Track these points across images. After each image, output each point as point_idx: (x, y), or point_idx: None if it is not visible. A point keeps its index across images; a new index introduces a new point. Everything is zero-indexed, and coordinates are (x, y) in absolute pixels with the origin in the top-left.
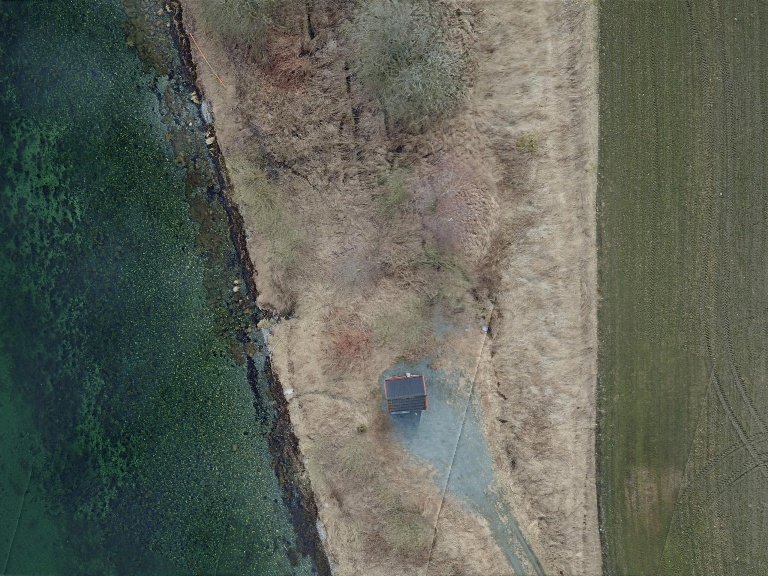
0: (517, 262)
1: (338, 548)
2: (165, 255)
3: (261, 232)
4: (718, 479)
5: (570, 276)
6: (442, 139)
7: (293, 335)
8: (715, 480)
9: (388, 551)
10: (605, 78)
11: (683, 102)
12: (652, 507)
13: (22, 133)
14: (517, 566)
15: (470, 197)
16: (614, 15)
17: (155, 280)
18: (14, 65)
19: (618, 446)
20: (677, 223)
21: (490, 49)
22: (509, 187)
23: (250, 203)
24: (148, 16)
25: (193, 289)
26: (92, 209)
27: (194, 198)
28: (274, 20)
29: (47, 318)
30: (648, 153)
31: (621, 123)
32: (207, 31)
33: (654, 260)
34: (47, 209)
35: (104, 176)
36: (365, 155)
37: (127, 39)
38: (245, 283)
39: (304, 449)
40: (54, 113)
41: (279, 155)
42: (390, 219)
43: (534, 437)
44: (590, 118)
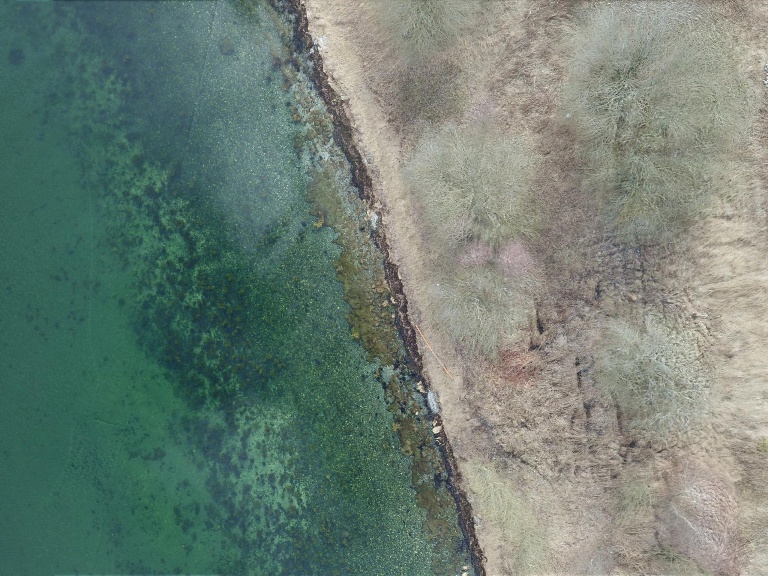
0: (756, 560)
1: None
2: (392, 541)
3: (490, 520)
4: None
5: None
6: (677, 436)
7: None
8: None
9: None
10: None
11: None
12: None
13: (246, 421)
14: None
15: (706, 494)
16: None
17: (382, 565)
18: (239, 356)
19: None
20: None
21: (729, 355)
22: (748, 488)
23: (479, 491)
24: (373, 307)
25: (421, 574)
26: (318, 495)
27: (421, 485)
28: None
29: None
30: None
31: None
32: (433, 323)
33: None
34: (272, 495)
35: (329, 463)
36: (597, 449)
37: (351, 329)
38: (474, 568)
39: None
40: (278, 401)
41: (508, 445)
42: (623, 511)
43: None
44: None
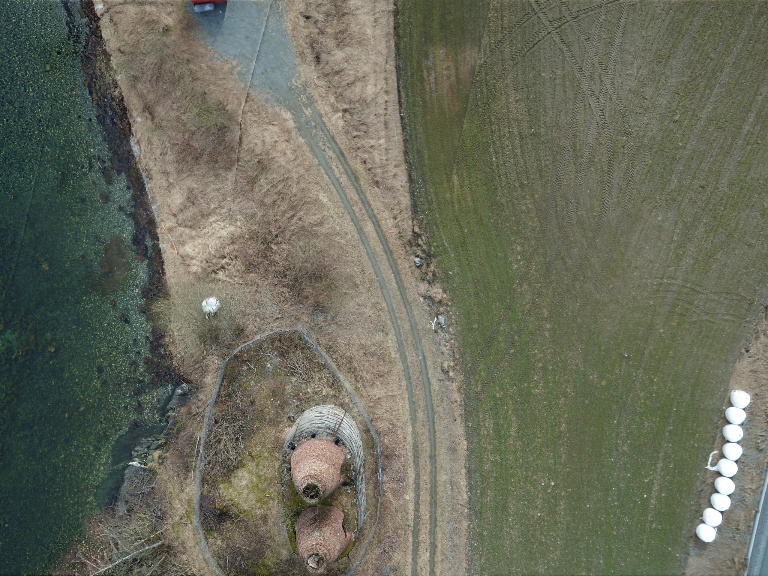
0: None
1: (151, 163)
2: None
3: None
4: (512, 51)
5: None
6: None
7: None
8: (510, 53)
9: (199, 159)
10: None
11: None
12: (450, 86)
13: None
14: (321, 157)
15: None
16: None
17: None
18: None
19: (416, 26)
20: None
21: None
22: None
23: None
24: None
25: None
26: None
27: None
28: None
29: None
30: None
31: None
32: None
33: None
34: None
35: None
36: None
37: None
38: None
39: (115, 63)
40: None
41: None
42: None
43: (335, 26)
44: None
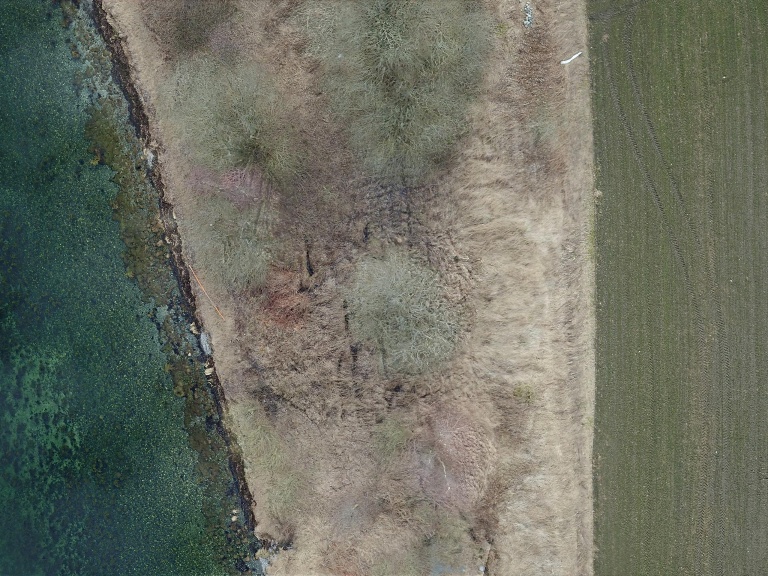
0: (514, 507)
1: None
2: (164, 483)
3: (259, 463)
4: None
5: (567, 527)
6: (440, 381)
7: (291, 566)
8: None
9: None
10: (602, 334)
11: (679, 361)
12: None
13: (22, 359)
14: None
15: (467, 439)
16: (611, 272)
17: (154, 507)
18: (14, 294)
19: None
20: (673, 479)
21: (488, 298)
22: (506, 433)
23: (249, 434)
24: (148, 247)
25: (192, 517)
26: (91, 436)
27: (193, 427)
28: (273, 255)
29: (46, 542)
30: (644, 409)
31: (617, 379)
32: (206, 264)
33: (650, 514)
34: (46, 435)
35: (103, 403)
36: (363, 393)
37: (127, 269)
38: (243, 512)
39: None
40: (54, 340)
41: (278, 388)
42: (388, 456)
43: None
44: (587, 372)
